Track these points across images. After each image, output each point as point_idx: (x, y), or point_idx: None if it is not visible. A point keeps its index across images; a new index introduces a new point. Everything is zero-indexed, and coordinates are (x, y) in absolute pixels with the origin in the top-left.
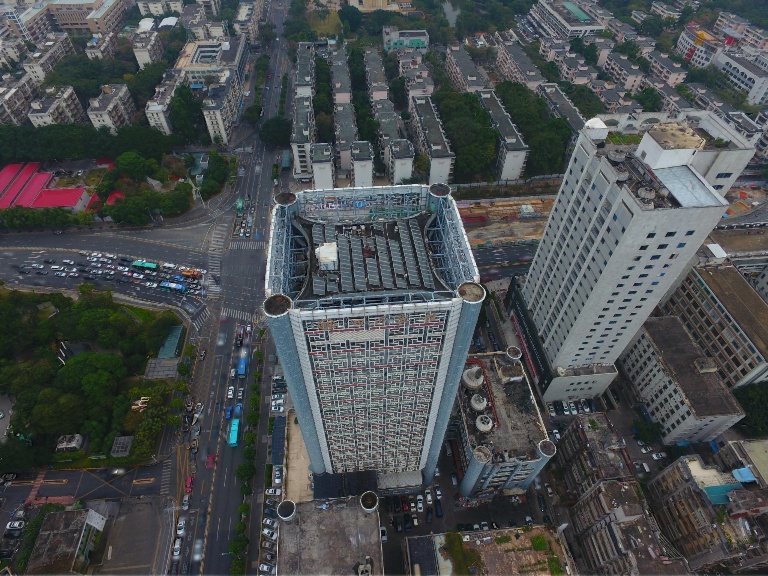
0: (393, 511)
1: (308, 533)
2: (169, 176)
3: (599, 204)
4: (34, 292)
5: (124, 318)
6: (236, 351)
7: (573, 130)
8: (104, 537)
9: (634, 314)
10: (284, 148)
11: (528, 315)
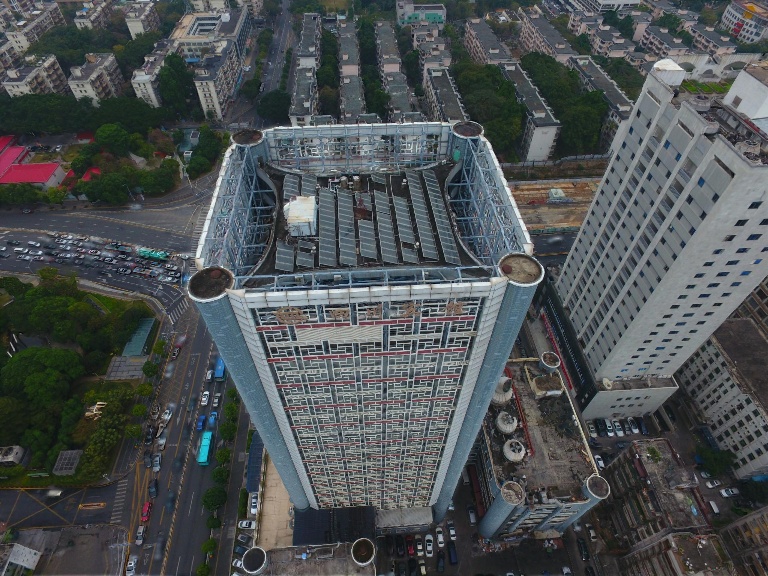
0: (395, 555)
1: None
2: (155, 153)
3: (675, 166)
4: None
5: (86, 308)
6: (215, 349)
7: (611, 104)
8: None
9: (709, 314)
10: (284, 125)
11: (564, 314)
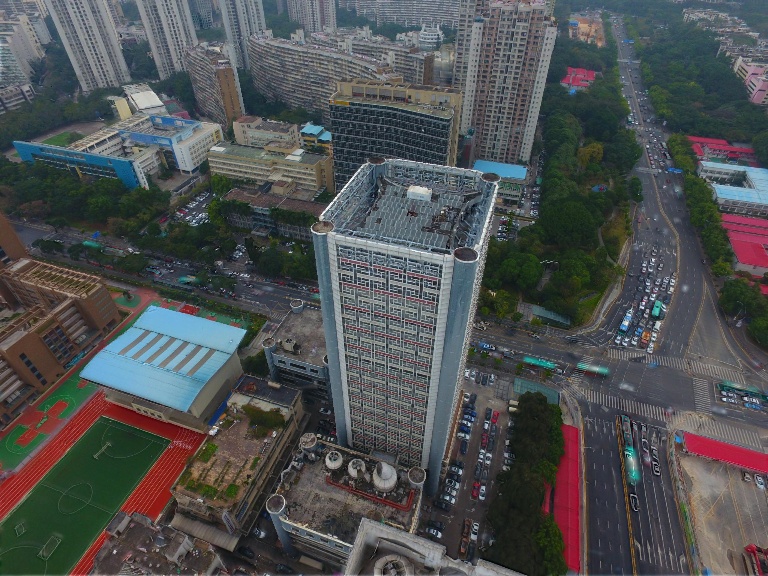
0: None
1: None
2: None
3: None
4: None
5: (575, 284)
6: (534, 358)
7: None
8: None
9: None
10: None
11: None
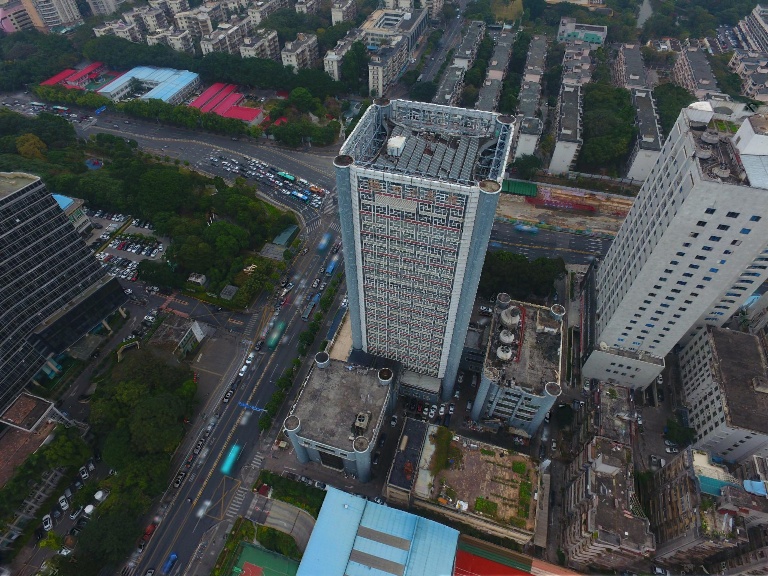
0: (408, 408)
1: (332, 381)
2: (326, 115)
3: (674, 178)
4: (206, 176)
5: (258, 207)
6: (331, 256)
7: None
8: (199, 347)
9: (689, 303)
10: None
11: (594, 293)
